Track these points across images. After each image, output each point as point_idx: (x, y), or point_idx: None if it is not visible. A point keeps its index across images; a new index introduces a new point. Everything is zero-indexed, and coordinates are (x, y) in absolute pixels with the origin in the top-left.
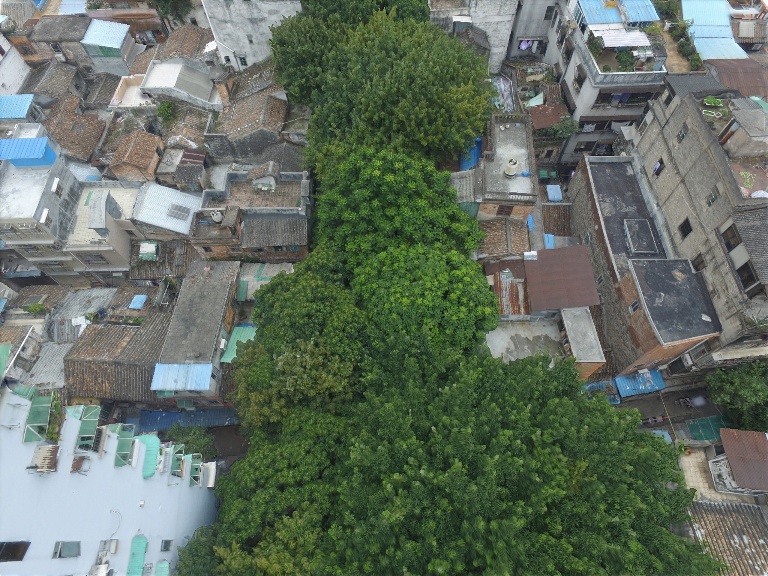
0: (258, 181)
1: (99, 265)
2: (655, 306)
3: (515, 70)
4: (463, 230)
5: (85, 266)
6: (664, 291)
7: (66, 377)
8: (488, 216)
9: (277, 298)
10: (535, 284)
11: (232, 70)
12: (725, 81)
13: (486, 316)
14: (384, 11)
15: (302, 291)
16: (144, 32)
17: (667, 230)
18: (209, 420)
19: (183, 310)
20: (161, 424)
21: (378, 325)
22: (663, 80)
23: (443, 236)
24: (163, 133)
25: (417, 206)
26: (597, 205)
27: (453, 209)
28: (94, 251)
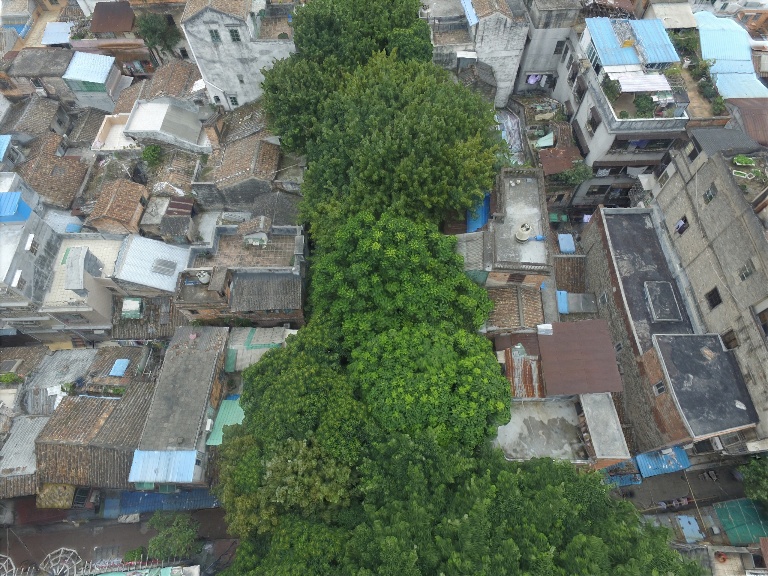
0: (249, 236)
1: (79, 323)
2: (683, 390)
3: (523, 108)
4: (471, 305)
5: (64, 324)
6: (693, 372)
7: (38, 461)
8: (498, 283)
9: (267, 381)
10: (550, 363)
11: (222, 110)
12: (749, 124)
13: (498, 412)
14: (384, 52)
15: (294, 381)
16: (131, 62)
17: (692, 295)
18: (195, 502)
19: (166, 387)
20: (143, 505)
21: (378, 421)
22: (684, 126)
23: (449, 311)
24: (148, 178)
25: (421, 282)
26: (615, 265)
27: (460, 279)
28: (72, 312)
